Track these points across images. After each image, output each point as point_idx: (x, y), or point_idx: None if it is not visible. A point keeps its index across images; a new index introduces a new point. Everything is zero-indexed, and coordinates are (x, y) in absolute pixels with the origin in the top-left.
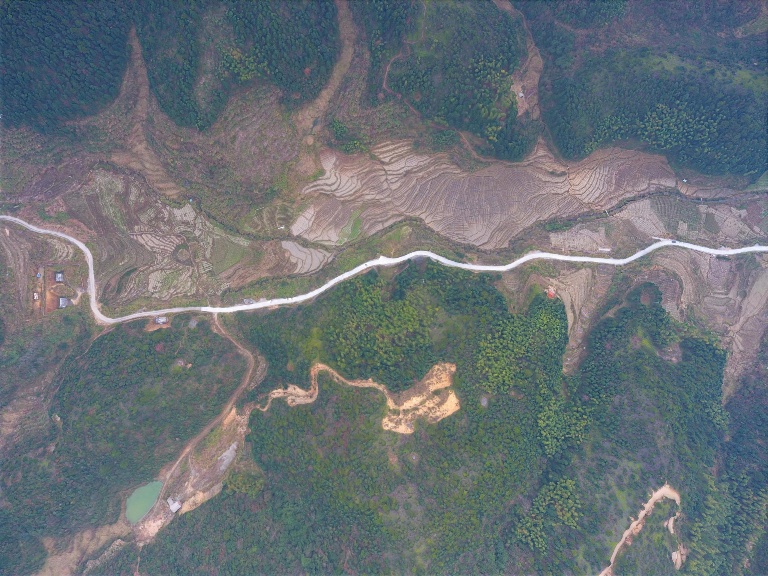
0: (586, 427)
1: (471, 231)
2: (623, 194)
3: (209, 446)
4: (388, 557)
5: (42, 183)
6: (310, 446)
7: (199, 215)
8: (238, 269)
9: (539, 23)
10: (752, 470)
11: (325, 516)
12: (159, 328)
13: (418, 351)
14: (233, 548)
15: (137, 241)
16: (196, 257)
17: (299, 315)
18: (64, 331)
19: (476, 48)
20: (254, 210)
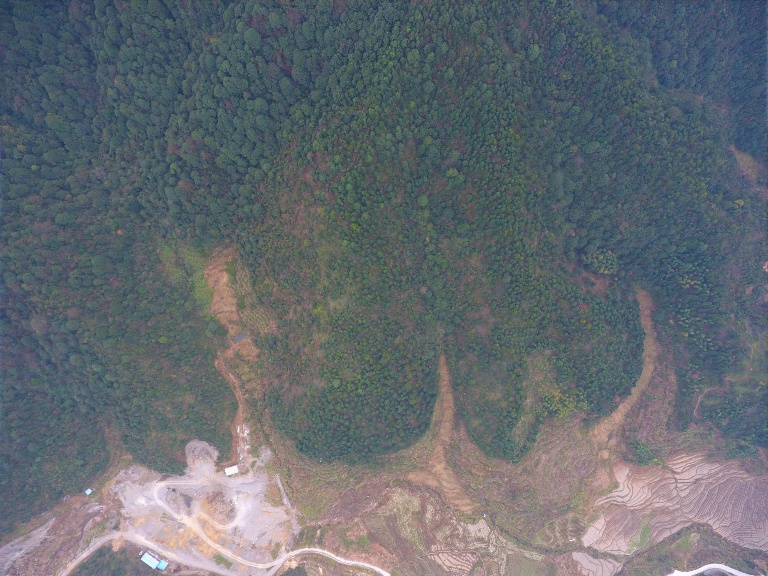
0: None
1: (759, 536)
2: None
3: None
4: None
5: (341, 504)
6: None
7: (493, 530)
8: None
9: None
10: None
11: None
12: None
13: None
14: None
15: (435, 562)
16: (490, 573)
17: None
18: None
19: None
20: (547, 524)
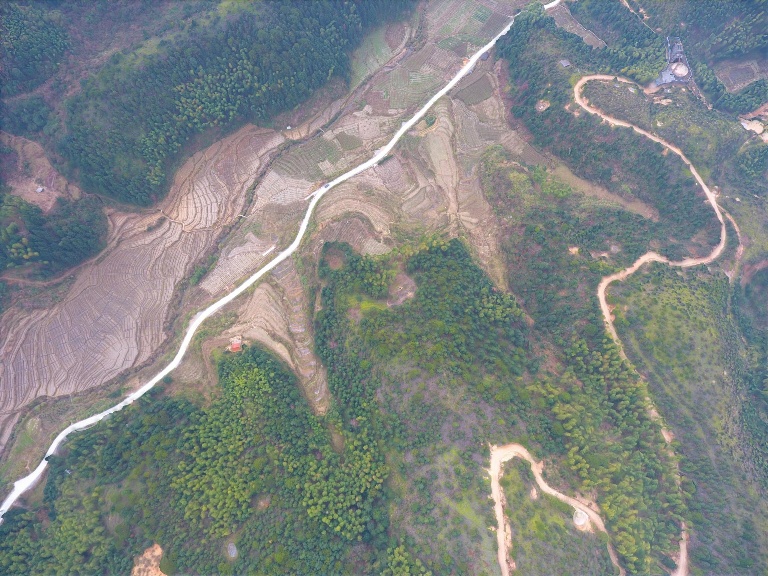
0: (375, 459)
1: (111, 358)
2: (243, 187)
3: None
4: None
5: None
6: None
7: None
8: None
9: None
10: (581, 329)
11: None
12: None
13: (107, 568)
14: None
15: None
16: None
17: None
18: None
19: None
20: None
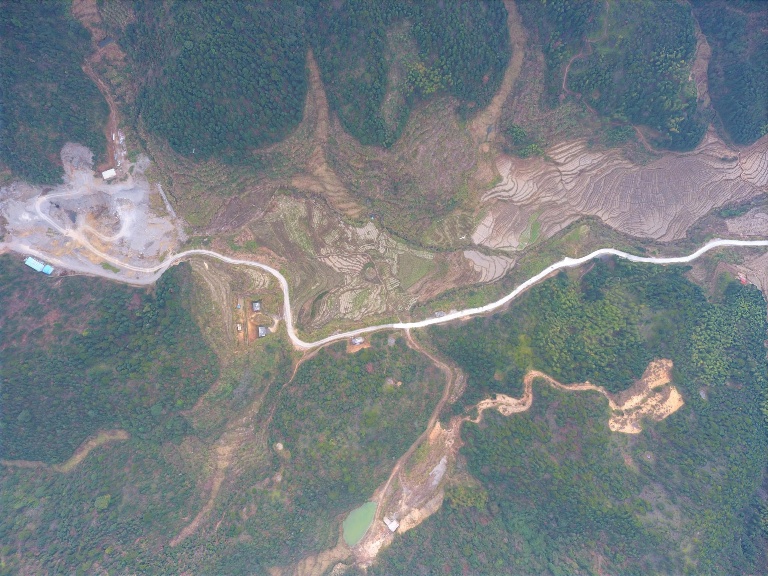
0: None
1: (648, 225)
2: None
3: (419, 462)
4: (649, 559)
5: (227, 214)
6: (543, 454)
7: (381, 232)
8: (425, 283)
9: (709, 10)
10: None
11: (568, 523)
12: (361, 349)
13: (629, 349)
14: (478, 562)
15: (325, 264)
16: (383, 274)
17: (498, 324)
18: (267, 360)
19: (657, 41)
20: (435, 222)
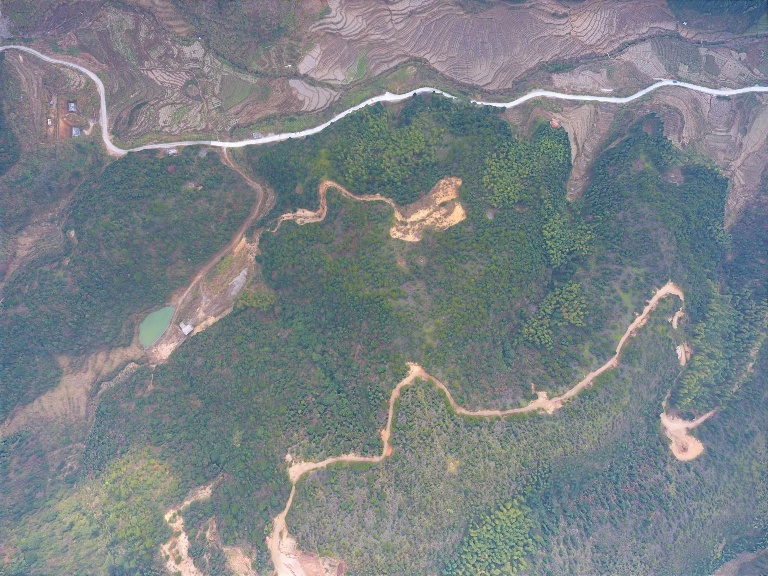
0: (590, 241)
1: (475, 71)
2: (624, 37)
3: (220, 273)
4: (398, 343)
5: (54, 19)
6: (320, 251)
7: (208, 53)
8: (246, 105)
9: None
10: (754, 285)
11: (335, 316)
12: (170, 155)
13: (424, 169)
14: (245, 348)
15: (147, 76)
16: (205, 93)
17: (307, 143)
18: (77, 159)
19: None
20: (262, 48)
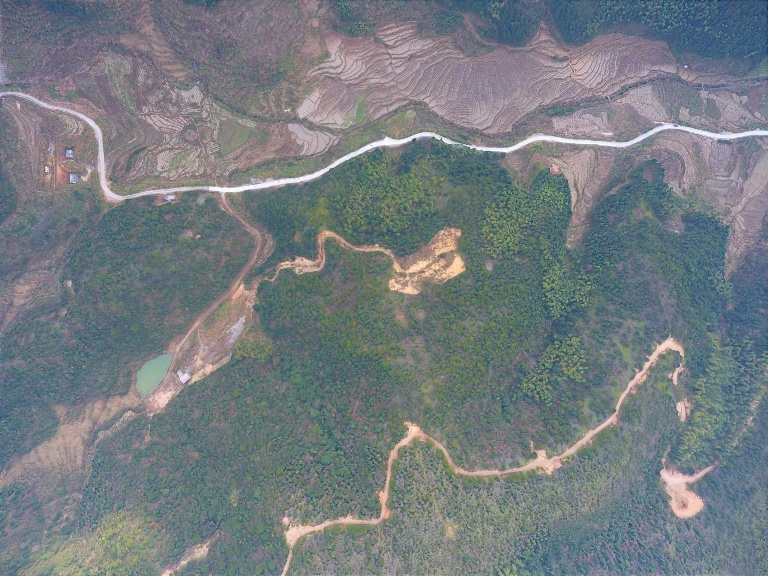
0: (590, 292)
1: (475, 115)
2: (625, 80)
3: (218, 320)
4: (396, 401)
5: (52, 64)
6: (318, 304)
7: (206, 97)
8: (245, 150)
9: None
10: (755, 336)
11: (333, 371)
12: (168, 202)
13: (424, 219)
14: (243, 403)
15: (146, 121)
16: (204, 138)
17: (306, 190)
18: (74, 206)
19: None
20: (260, 92)
